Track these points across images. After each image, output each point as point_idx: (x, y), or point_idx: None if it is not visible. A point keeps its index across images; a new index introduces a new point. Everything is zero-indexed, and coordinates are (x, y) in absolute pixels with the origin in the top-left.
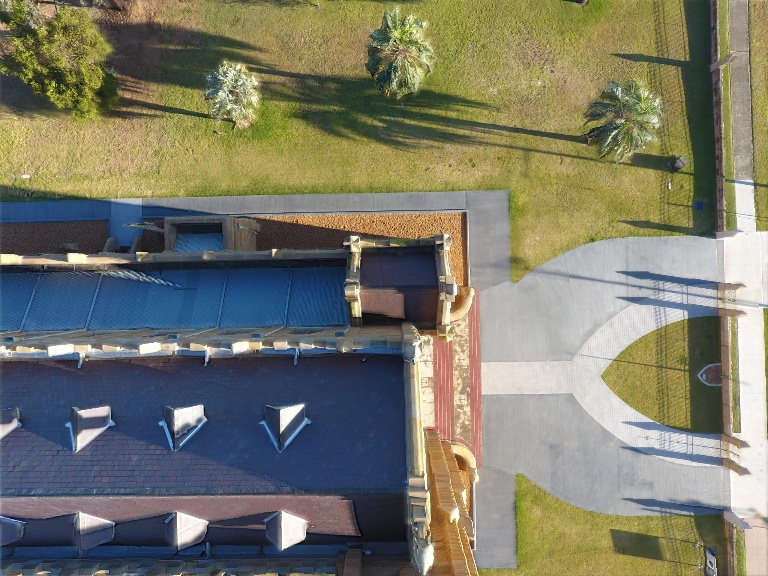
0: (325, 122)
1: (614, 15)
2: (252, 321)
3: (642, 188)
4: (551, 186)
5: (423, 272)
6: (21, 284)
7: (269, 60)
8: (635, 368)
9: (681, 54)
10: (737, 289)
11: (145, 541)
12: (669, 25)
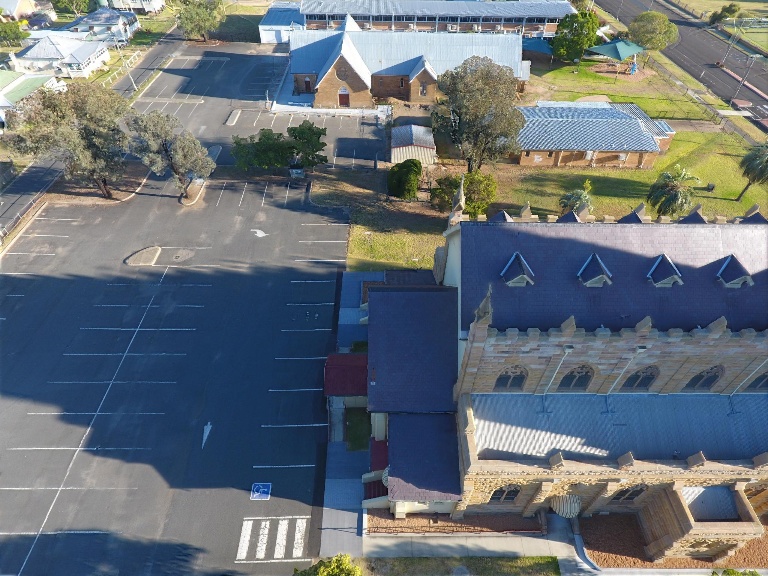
0: None
1: (761, 206)
2: None
3: None
4: None
5: None
6: None
7: None
8: None
9: None
10: None
11: (752, 322)
12: None
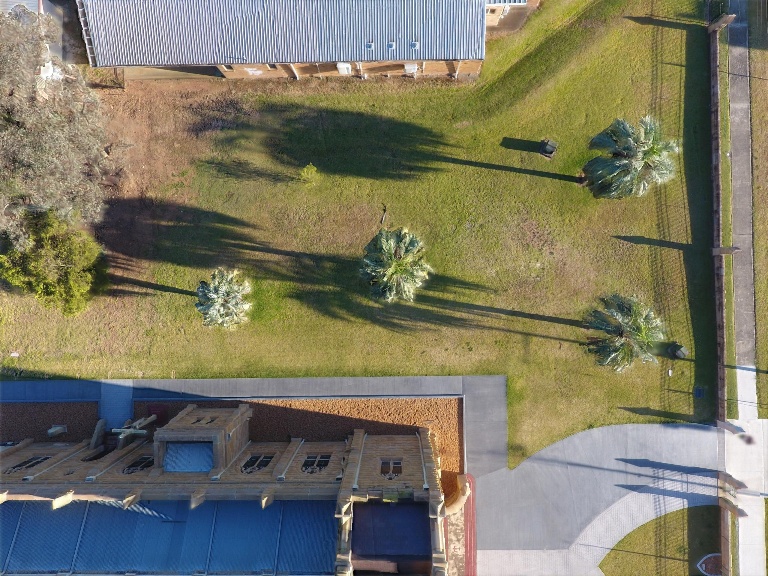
0: (320, 302)
1: None
2: (242, 565)
3: (642, 374)
4: (549, 371)
5: (417, 534)
6: (6, 514)
7: (263, 237)
8: (633, 557)
9: (683, 237)
10: (738, 489)
11: None
12: (671, 207)
